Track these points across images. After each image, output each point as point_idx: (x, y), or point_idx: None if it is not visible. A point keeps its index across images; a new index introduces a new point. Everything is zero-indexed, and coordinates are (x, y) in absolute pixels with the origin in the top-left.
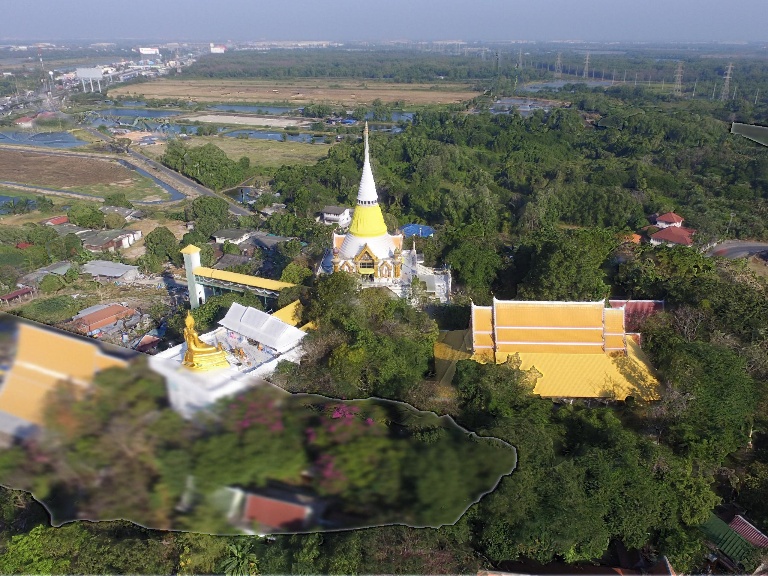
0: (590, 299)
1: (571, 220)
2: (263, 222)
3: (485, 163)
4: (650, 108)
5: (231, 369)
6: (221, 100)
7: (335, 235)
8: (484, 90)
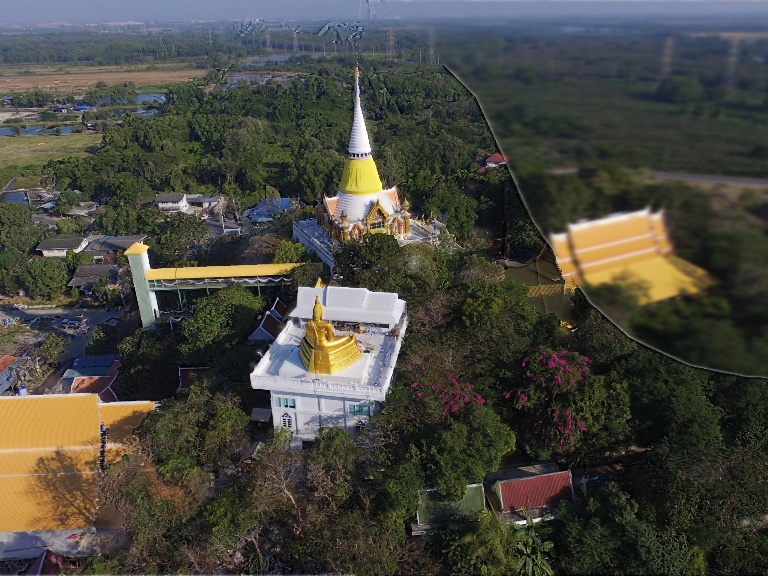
0: None
1: None
2: (89, 224)
3: (281, 133)
4: None
5: (368, 359)
6: None
7: (326, 199)
8: (213, 66)
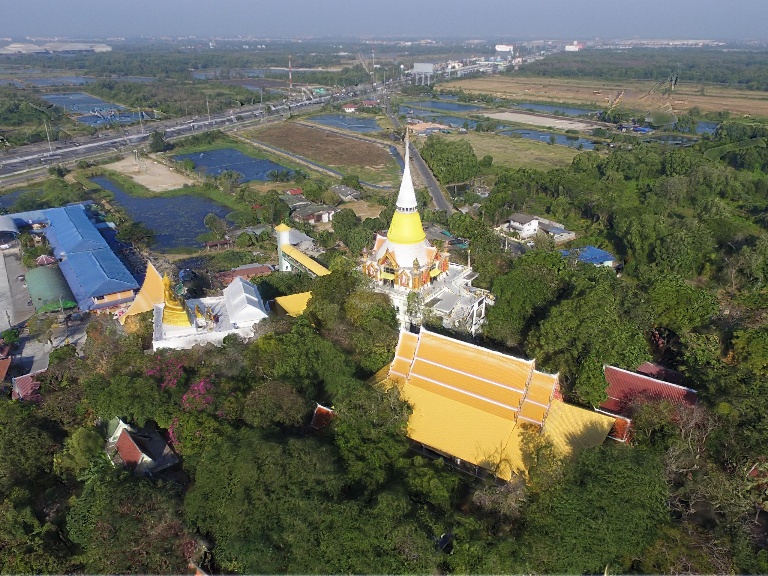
0: (604, 364)
1: None
2: None
3: (762, 193)
4: None
5: (189, 329)
6: (529, 98)
7: (379, 236)
8: None
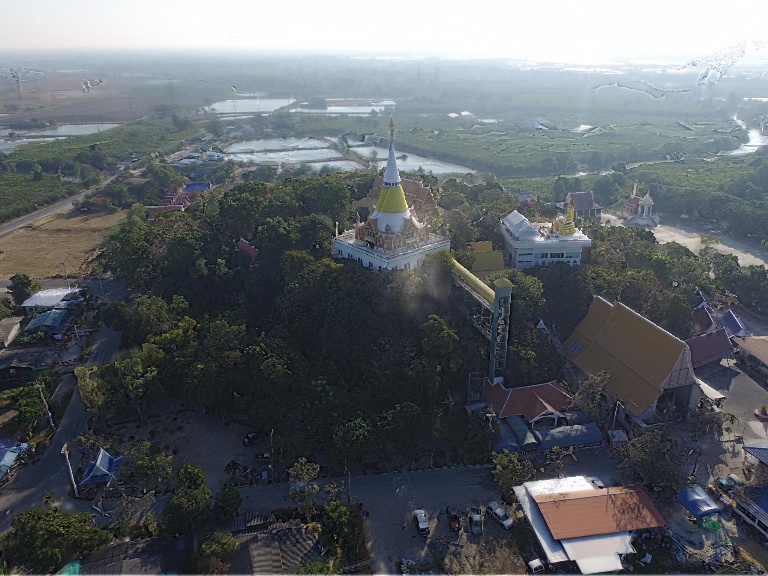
0: None
1: None
2: None
3: None
4: None
5: None
6: None
7: None
8: None
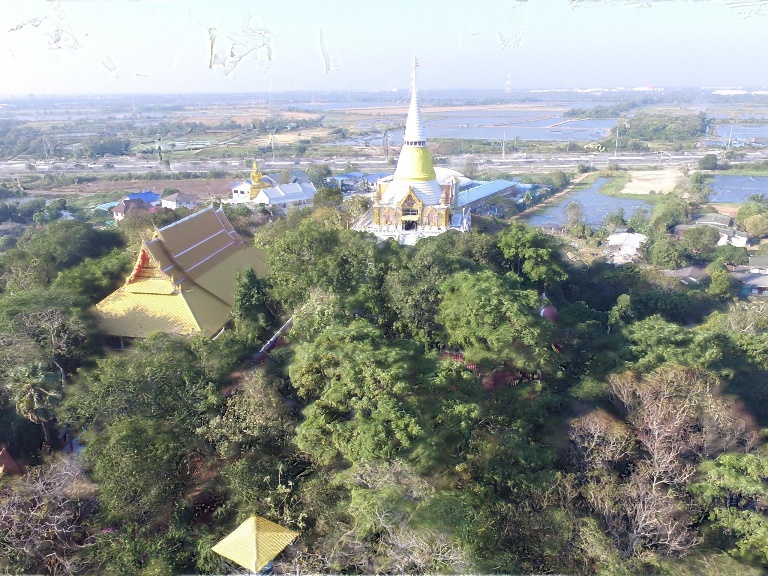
0: (296, 310)
1: None
2: None
3: None
4: None
5: None
6: None
7: None
8: None
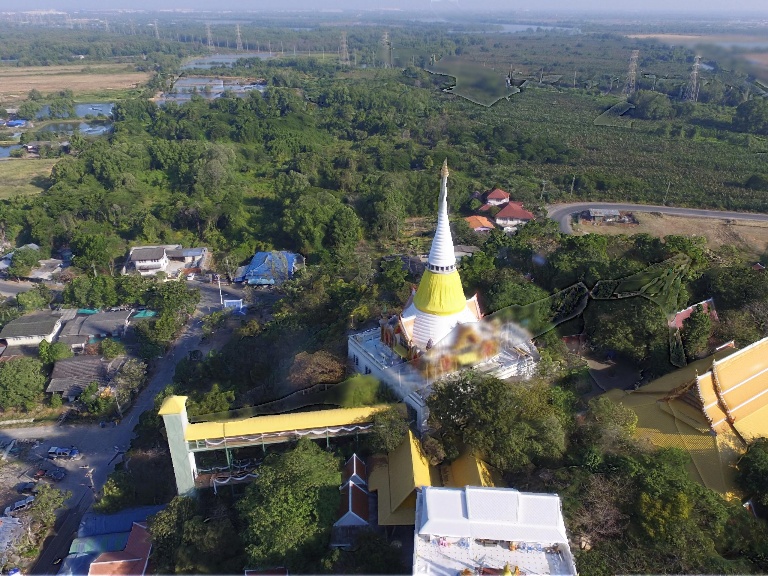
0: None
1: (407, 212)
2: (56, 295)
3: (252, 159)
4: (343, 80)
5: None
6: None
7: (403, 320)
8: (156, 70)
